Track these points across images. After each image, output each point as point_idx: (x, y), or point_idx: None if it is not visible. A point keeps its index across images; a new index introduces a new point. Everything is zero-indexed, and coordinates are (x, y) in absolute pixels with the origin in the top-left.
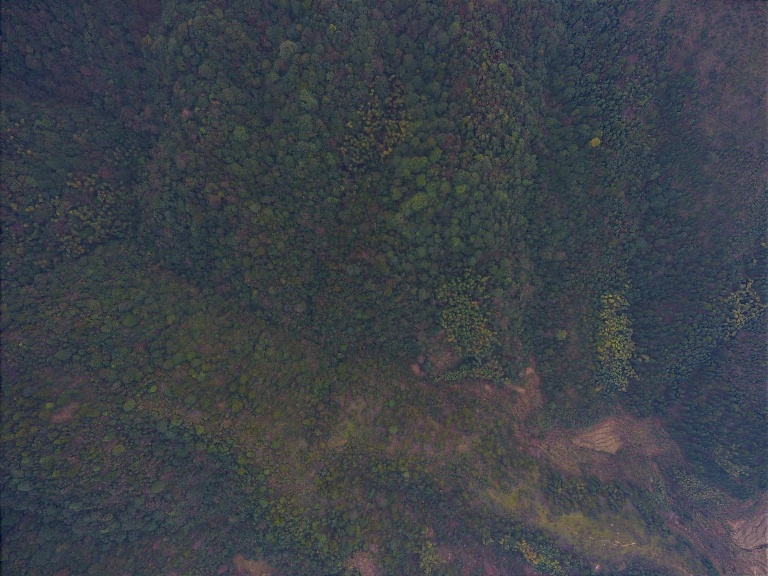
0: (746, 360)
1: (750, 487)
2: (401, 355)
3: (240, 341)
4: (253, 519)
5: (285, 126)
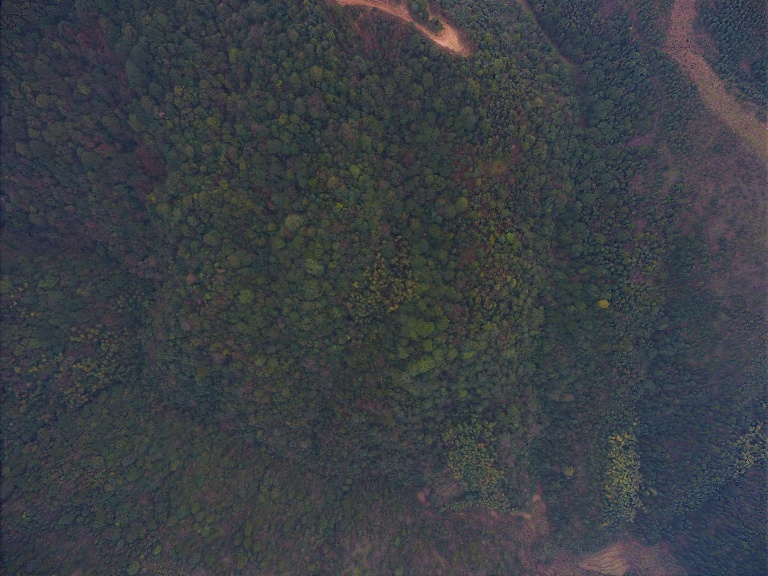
0: (755, 498)
1: None
2: (406, 485)
3: (245, 484)
4: None
5: (291, 287)
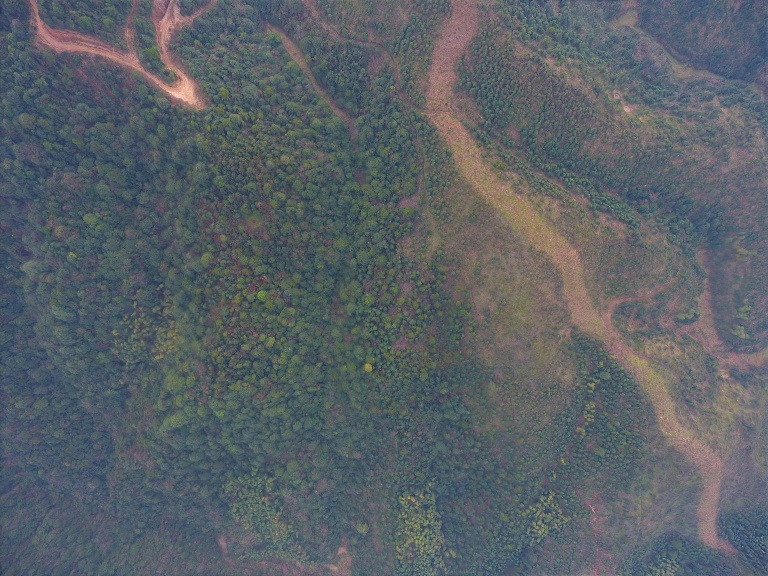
0: (550, 568)
1: None
2: (205, 531)
3: (18, 525)
4: None
5: (47, 330)
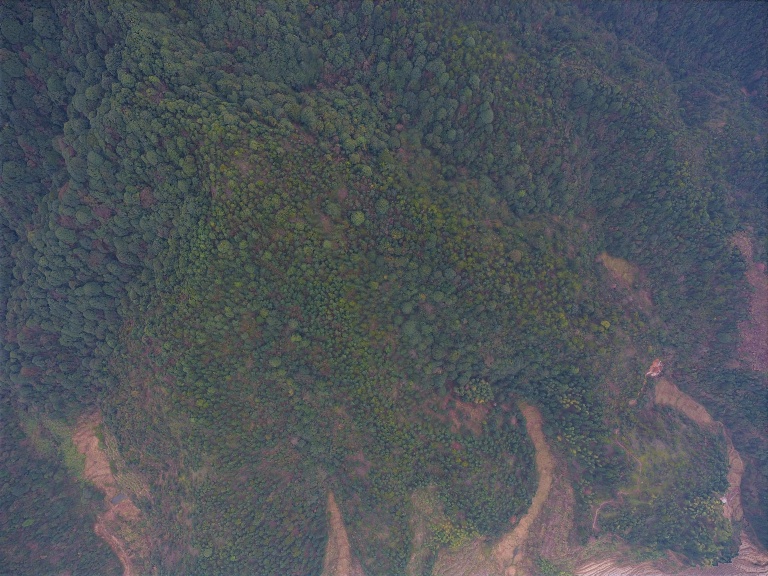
0: None
1: None
2: (734, 74)
3: None
4: (646, 193)
5: None
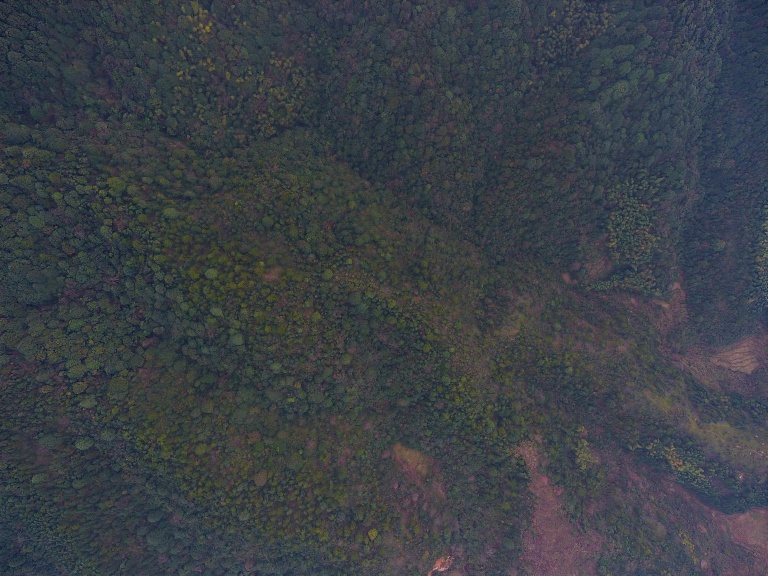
0: None
1: None
2: (555, 262)
3: (415, 231)
4: (428, 400)
5: (492, 12)
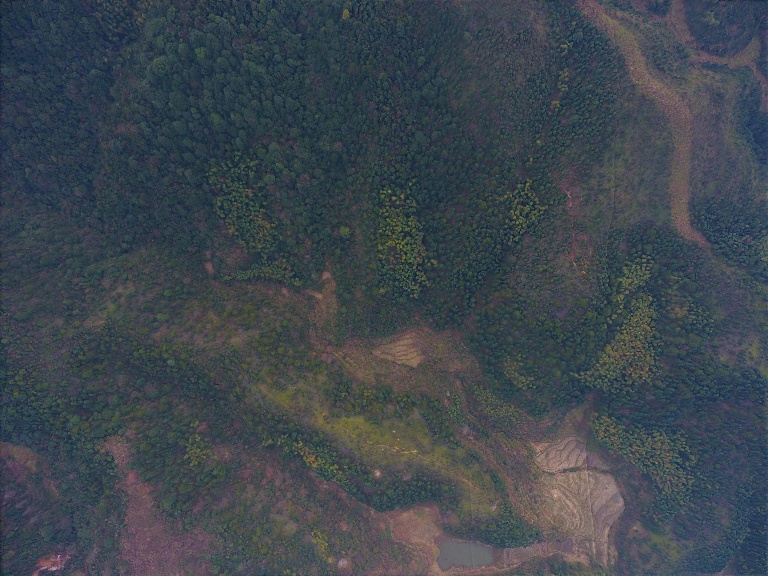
0: (528, 266)
1: (542, 403)
2: (191, 250)
3: (6, 217)
4: None
5: None
